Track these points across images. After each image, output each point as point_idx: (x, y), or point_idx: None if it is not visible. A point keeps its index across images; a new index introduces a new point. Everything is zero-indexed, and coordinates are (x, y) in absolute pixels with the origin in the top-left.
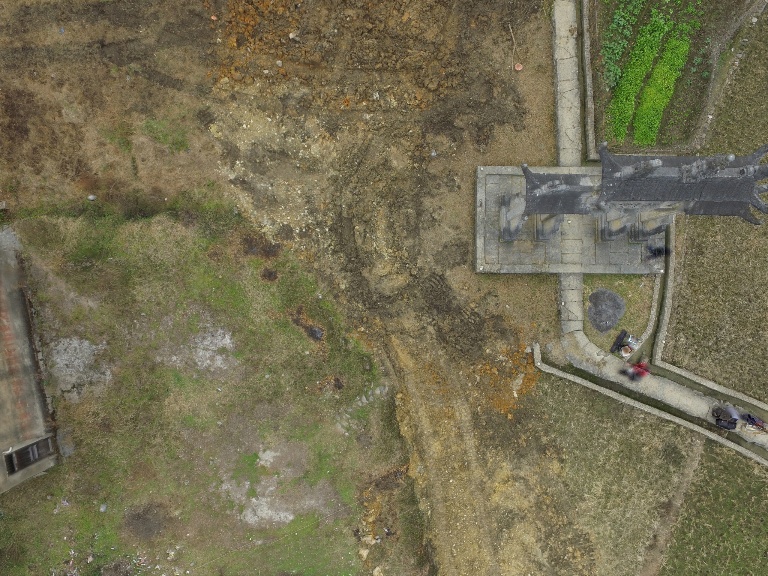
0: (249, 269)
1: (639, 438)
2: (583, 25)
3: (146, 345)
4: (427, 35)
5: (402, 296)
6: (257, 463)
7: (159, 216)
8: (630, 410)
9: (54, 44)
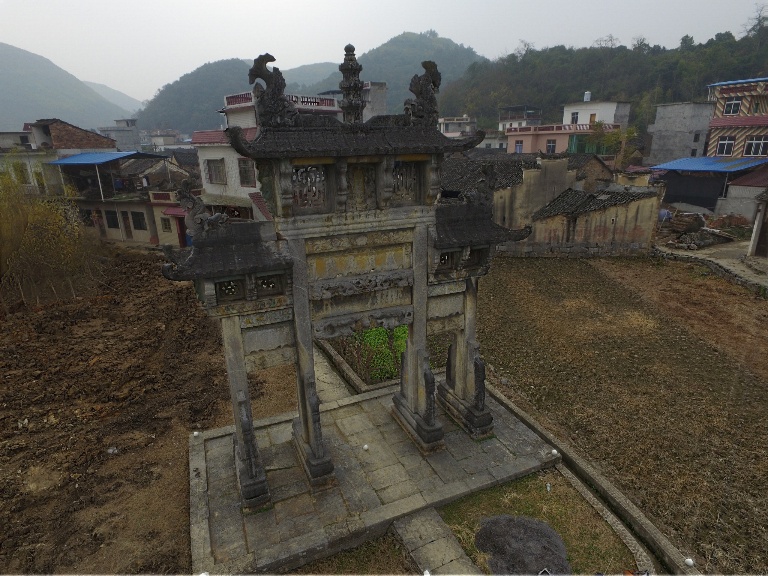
0: None
1: None
2: None
3: None
4: (122, 366)
5: None
6: None
7: None
8: None
9: None
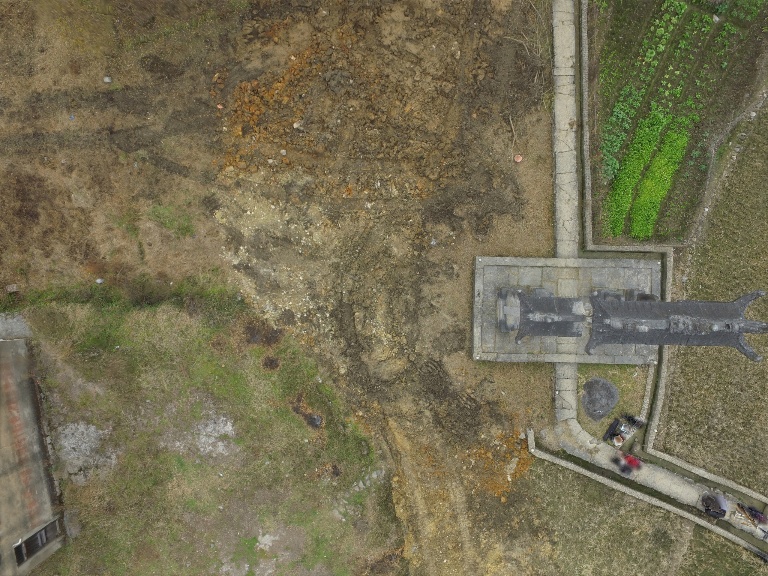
0: (251, 359)
1: (630, 523)
2: (582, 118)
3: (151, 431)
4: (428, 126)
5: (400, 380)
6: (257, 547)
7: (164, 305)
8: (621, 495)
9: (64, 130)
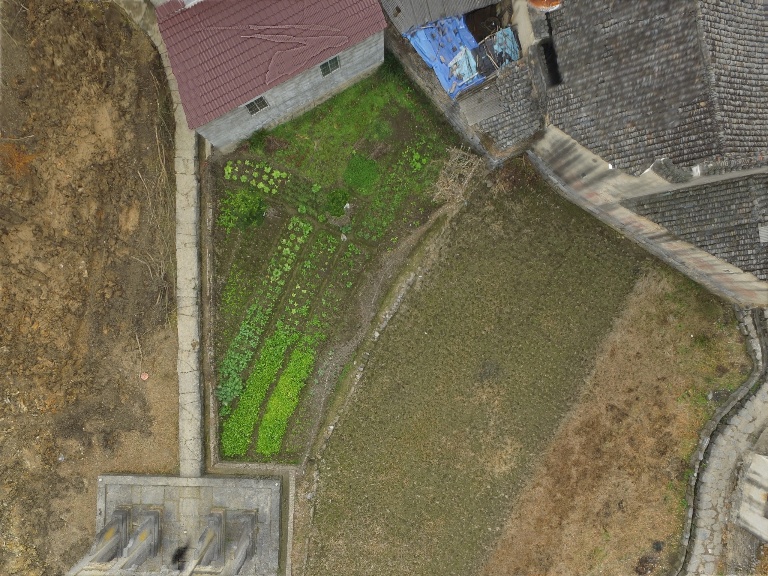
0: None
1: None
2: None
3: None
4: (57, 342)
5: None
6: None
7: None
8: None
9: None
